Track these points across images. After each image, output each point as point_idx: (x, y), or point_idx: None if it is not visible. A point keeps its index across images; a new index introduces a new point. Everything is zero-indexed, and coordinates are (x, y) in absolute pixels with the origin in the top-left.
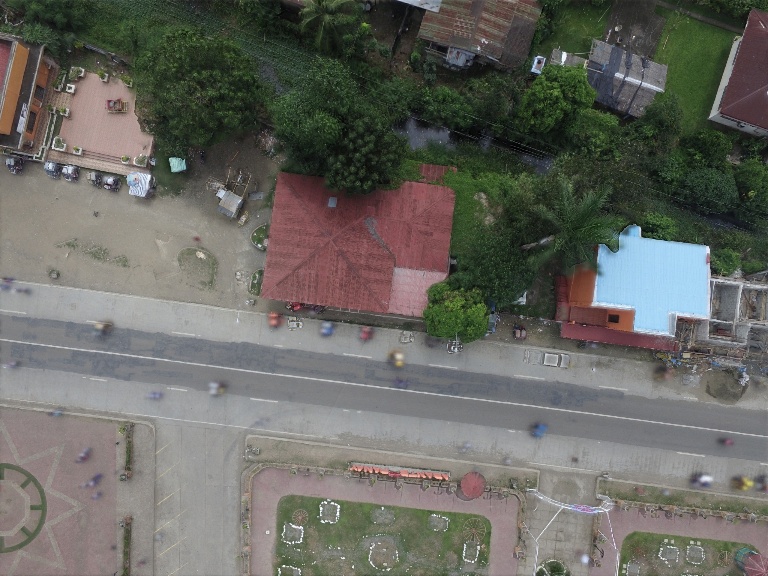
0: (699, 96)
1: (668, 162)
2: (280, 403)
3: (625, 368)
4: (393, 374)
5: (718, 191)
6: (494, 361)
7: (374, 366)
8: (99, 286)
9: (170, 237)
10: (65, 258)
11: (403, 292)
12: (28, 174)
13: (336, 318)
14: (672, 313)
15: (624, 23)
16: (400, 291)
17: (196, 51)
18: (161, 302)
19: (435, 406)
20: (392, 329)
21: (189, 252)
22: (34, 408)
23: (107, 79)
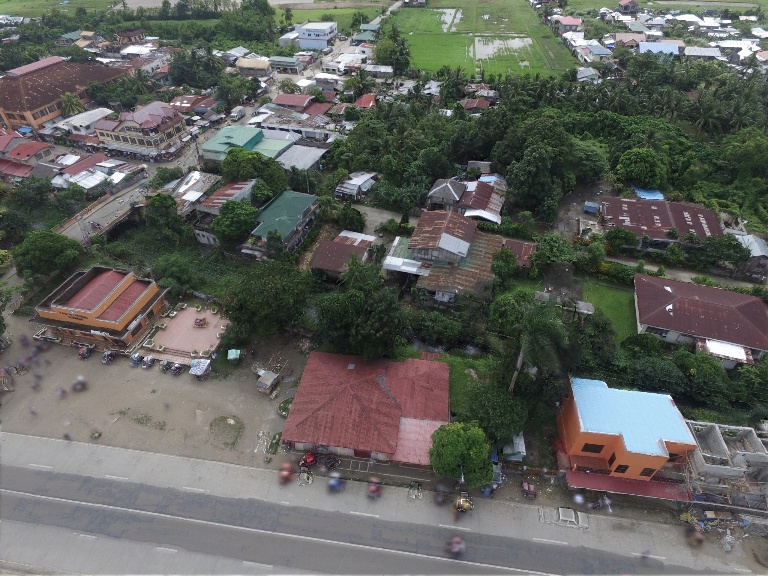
0: (625, 324)
1: (616, 355)
2: (275, 568)
3: (652, 532)
4: (402, 535)
5: (665, 372)
6: (508, 522)
7: (381, 526)
8: (132, 445)
9: (209, 408)
10: (113, 422)
11: (409, 440)
12: (114, 364)
13: (345, 476)
14: (659, 439)
15: (554, 287)
16: (407, 439)
17: (274, 267)
18: (183, 459)
19: (450, 575)
20: (400, 487)
21: (222, 419)
22: (3, 569)
23: (200, 309)
